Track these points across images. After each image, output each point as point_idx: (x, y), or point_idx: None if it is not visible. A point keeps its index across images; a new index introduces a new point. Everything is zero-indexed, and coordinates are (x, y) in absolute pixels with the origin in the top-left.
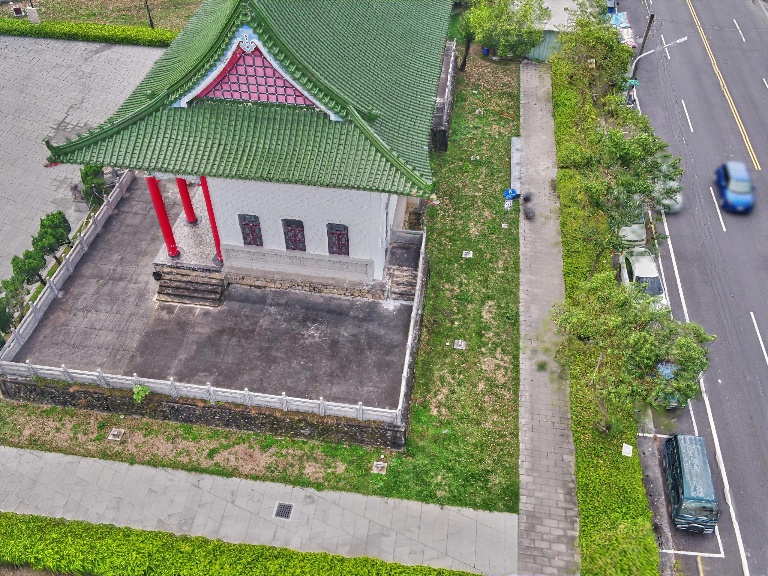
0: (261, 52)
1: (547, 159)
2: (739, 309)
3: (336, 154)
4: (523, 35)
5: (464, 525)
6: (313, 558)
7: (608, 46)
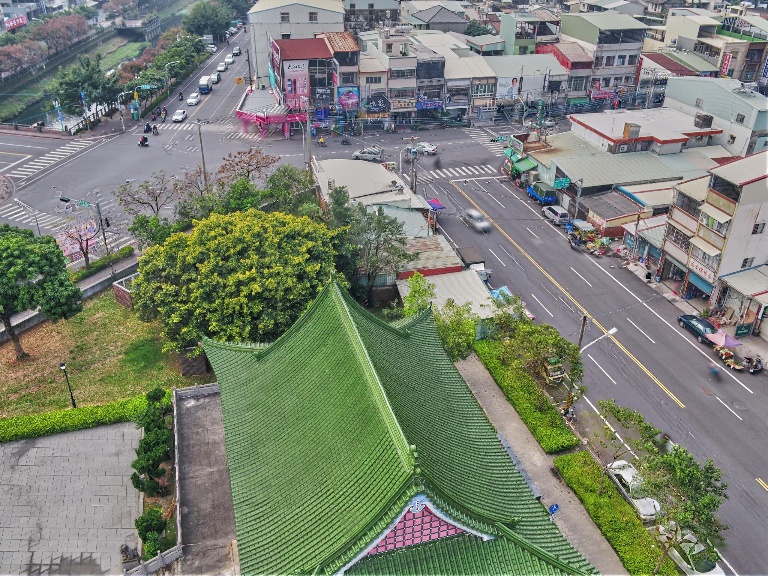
0: (427, 508)
1: (532, 447)
2: (766, 553)
3: (503, 574)
4: (470, 342)
5: None
6: None
7: (561, 348)
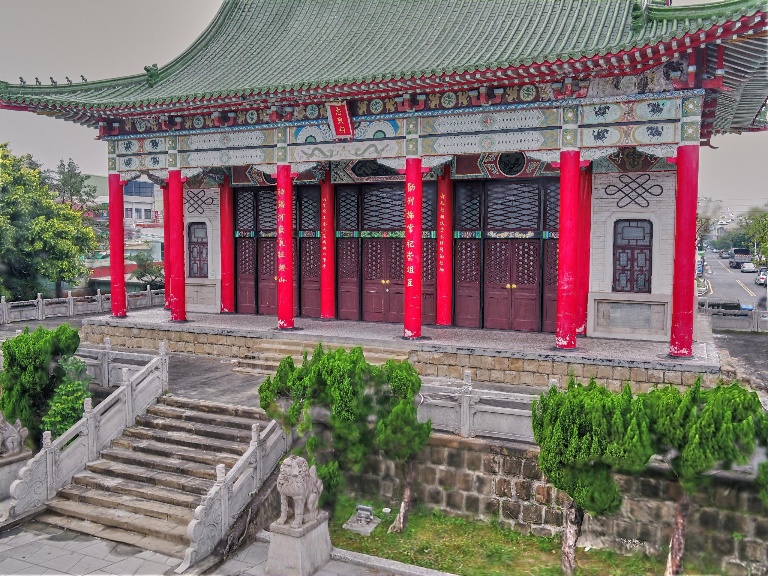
0: None
1: None
2: None
3: None
4: None
5: None
6: None
7: None
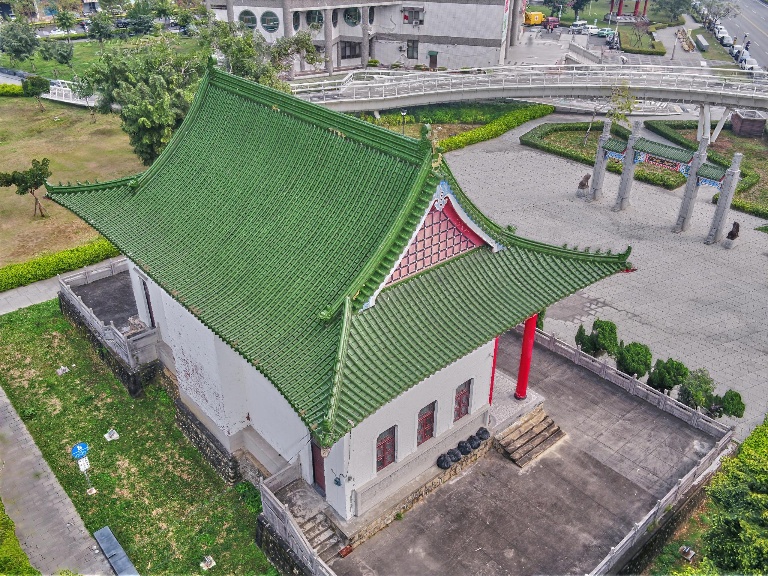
0: None
1: None
2: None
3: None
4: None
5: (1, 309)
6: (74, 259)
7: None
